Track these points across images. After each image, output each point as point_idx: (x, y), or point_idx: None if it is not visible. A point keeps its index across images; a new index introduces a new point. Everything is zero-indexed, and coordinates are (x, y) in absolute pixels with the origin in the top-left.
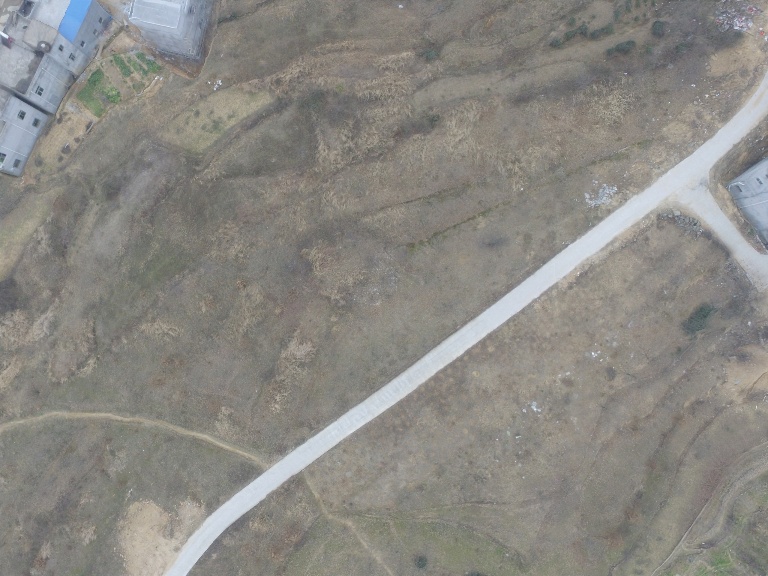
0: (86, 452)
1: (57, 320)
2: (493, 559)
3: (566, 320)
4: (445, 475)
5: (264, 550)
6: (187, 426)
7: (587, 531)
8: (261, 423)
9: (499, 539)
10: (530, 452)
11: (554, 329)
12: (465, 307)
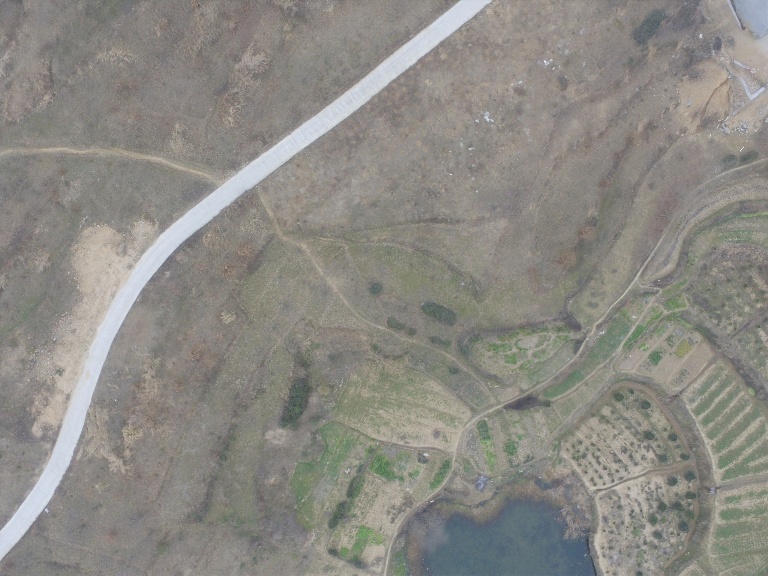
0: (42, 187)
1: (14, 63)
2: (449, 288)
3: (518, 26)
4: (399, 190)
5: (218, 268)
6: (142, 151)
7: (541, 254)
8: (215, 139)
9: (454, 263)
10: (483, 165)
11: (506, 35)
12: (418, 13)
